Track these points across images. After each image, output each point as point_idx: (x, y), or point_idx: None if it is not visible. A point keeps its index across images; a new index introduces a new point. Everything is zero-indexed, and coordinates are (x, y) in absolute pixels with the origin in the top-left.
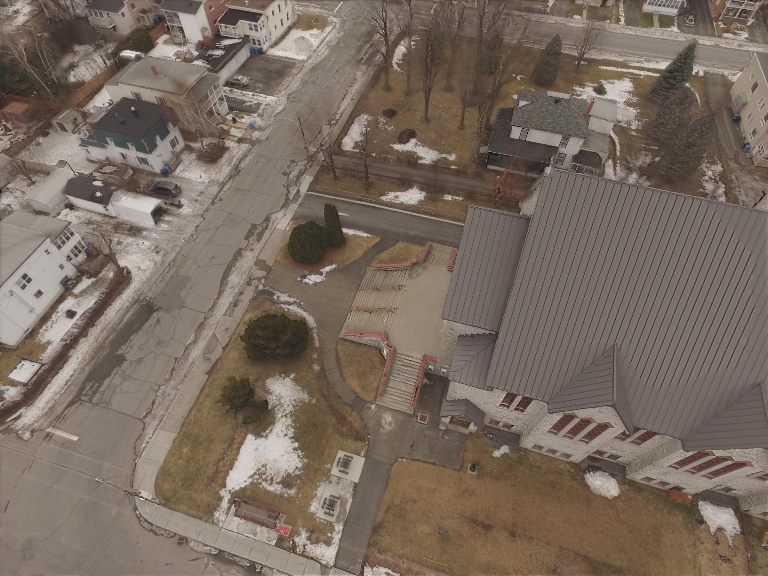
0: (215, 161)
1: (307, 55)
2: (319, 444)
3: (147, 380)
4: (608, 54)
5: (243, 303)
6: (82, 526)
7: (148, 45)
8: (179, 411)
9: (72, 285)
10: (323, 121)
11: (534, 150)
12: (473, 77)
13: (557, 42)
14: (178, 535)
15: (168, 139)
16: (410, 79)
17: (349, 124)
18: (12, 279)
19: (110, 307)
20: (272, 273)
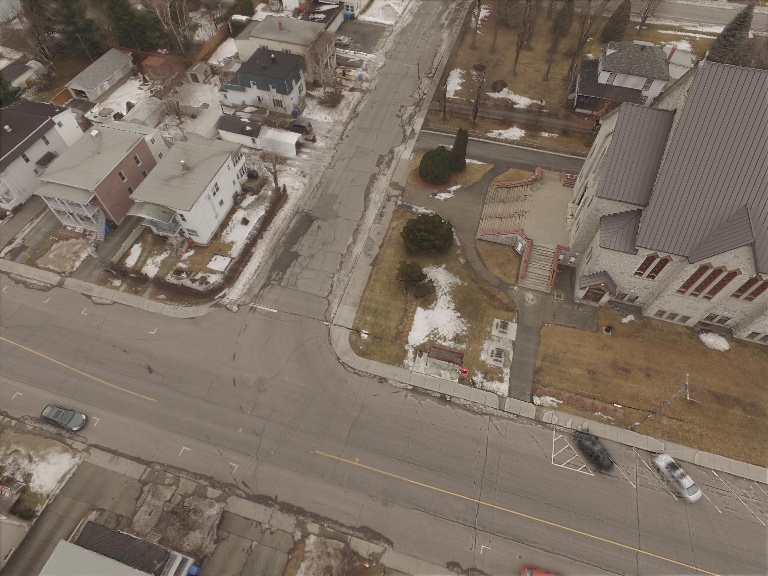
0: (335, 106)
1: (394, 20)
2: (477, 314)
3: (322, 270)
4: (665, 20)
5: (387, 214)
6: (299, 370)
7: (250, 11)
8: (355, 292)
9: (240, 200)
10: (421, 74)
11: (620, 93)
12: None
13: (628, 5)
14: (378, 376)
15: (298, 85)
16: (495, 38)
17: (446, 76)
18: (210, 185)
19: (276, 217)
20: (407, 192)
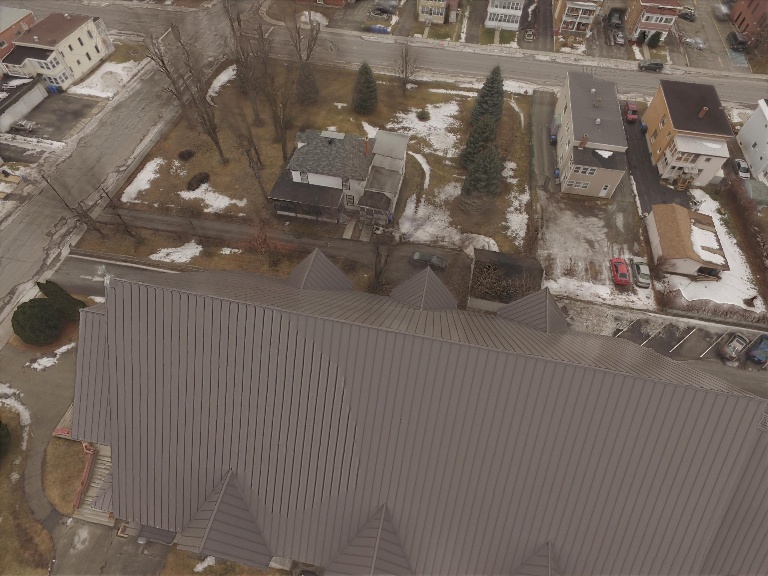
0: None
1: (114, 91)
2: None
3: None
4: (440, 75)
5: None
6: None
7: None
8: None
9: None
10: (111, 168)
11: (317, 194)
12: (271, 113)
13: (365, 70)
14: None
15: None
16: None
17: (137, 170)
18: None
19: None
20: None
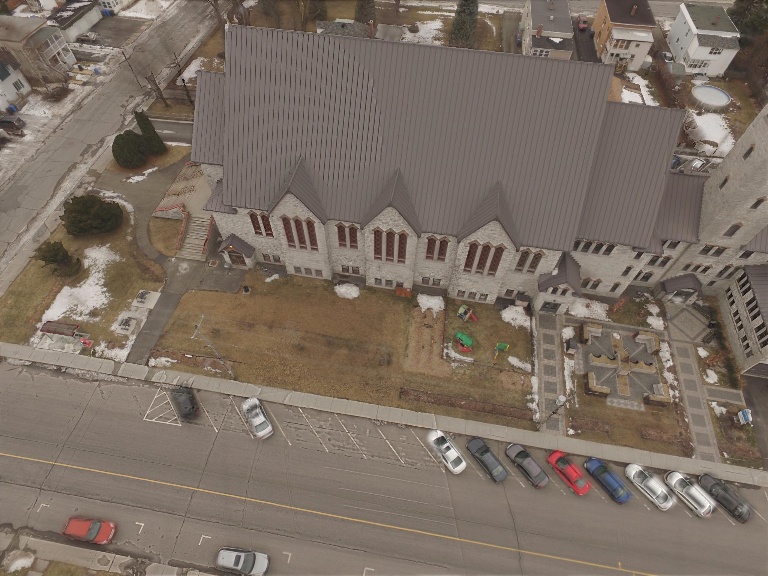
0: (59, 100)
1: (156, 15)
2: (124, 287)
3: None
4: (427, 2)
5: None
6: None
7: (4, 13)
8: (7, 278)
9: None
10: (164, 65)
11: None
12: (292, 19)
13: None
14: None
15: (10, 81)
16: None
17: (186, 65)
18: None
19: None
20: (101, 178)
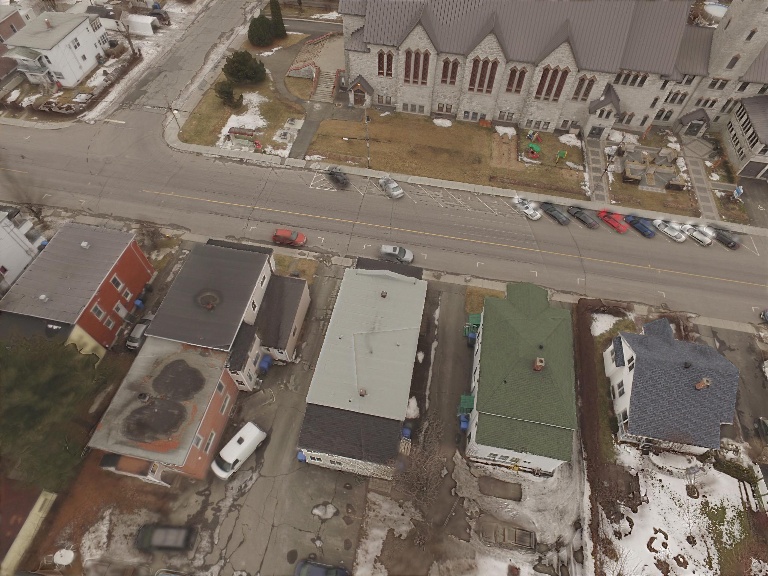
0: (191, 3)
1: None
2: (276, 116)
3: (164, 99)
4: None
5: (221, 66)
6: (137, 152)
7: None
8: (187, 110)
9: (103, 61)
10: None
11: None
12: None
13: None
14: (196, 152)
15: None
16: None
17: None
18: (70, 37)
19: (131, 71)
20: None
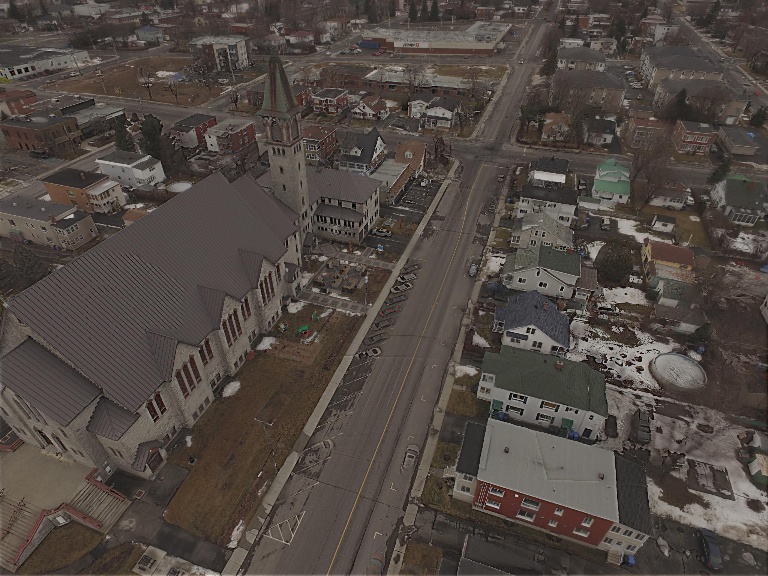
0: None
1: None
2: None
3: None
4: None
5: None
6: None
7: None
8: None
9: None
10: None
11: None
12: None
13: None
14: None
15: None
16: None
17: None
18: None
19: None
20: None
